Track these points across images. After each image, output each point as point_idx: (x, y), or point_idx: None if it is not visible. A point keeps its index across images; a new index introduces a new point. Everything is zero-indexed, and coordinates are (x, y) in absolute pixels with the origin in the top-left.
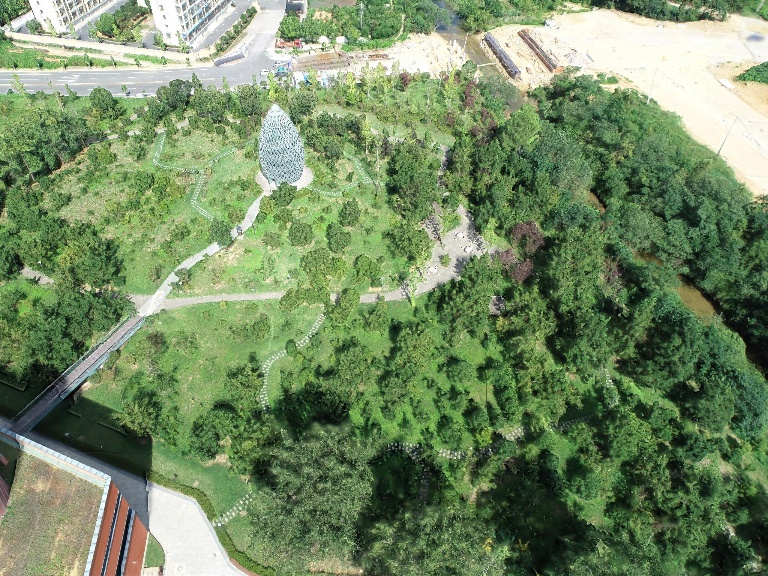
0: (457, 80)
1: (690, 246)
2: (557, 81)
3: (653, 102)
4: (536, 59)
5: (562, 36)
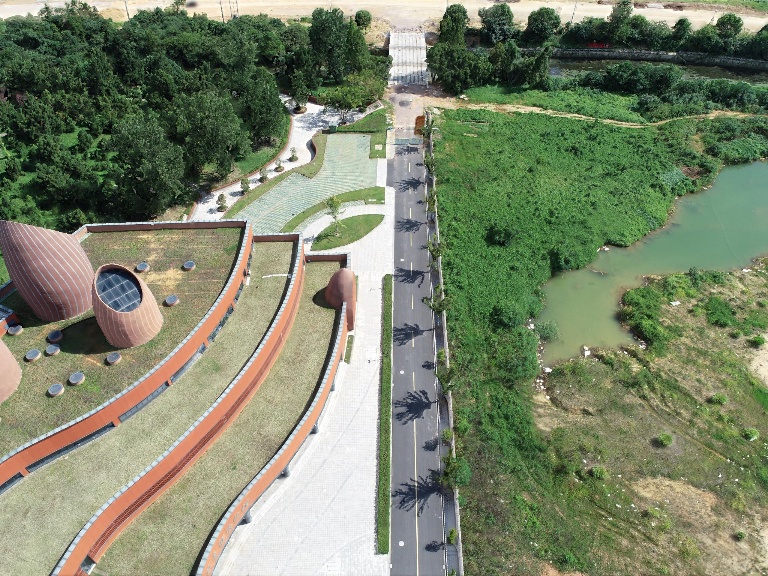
0: None
1: (50, 55)
2: None
3: None
4: None
5: None
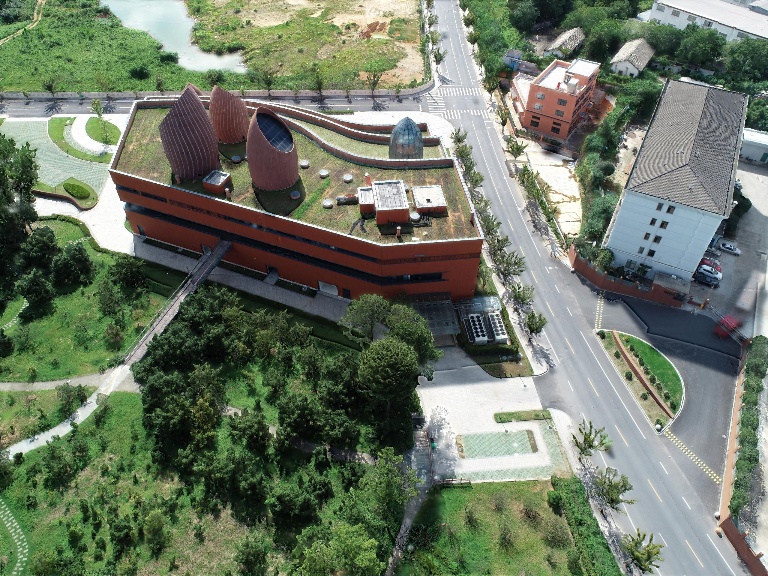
0: None
1: None
2: None
3: None
4: None
5: None
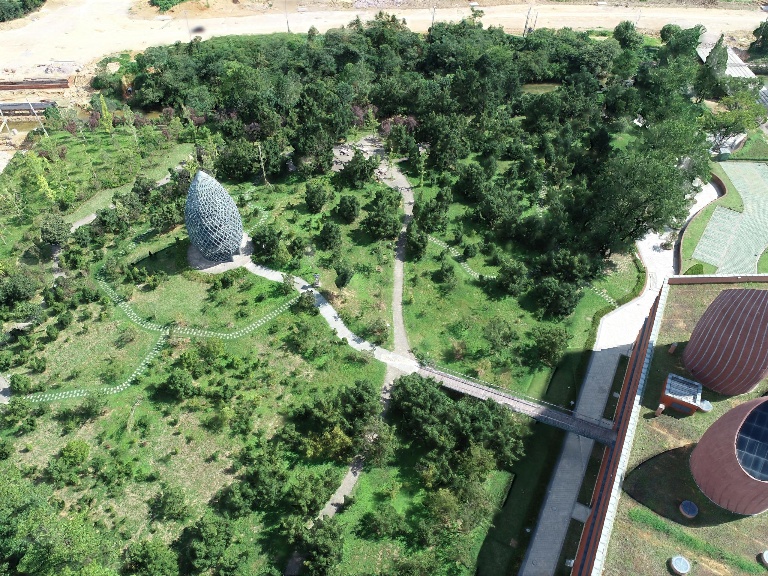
0: (90, 119)
1: (369, 71)
2: (110, 79)
3: (184, 44)
4: (32, 91)
5: (3, 67)
